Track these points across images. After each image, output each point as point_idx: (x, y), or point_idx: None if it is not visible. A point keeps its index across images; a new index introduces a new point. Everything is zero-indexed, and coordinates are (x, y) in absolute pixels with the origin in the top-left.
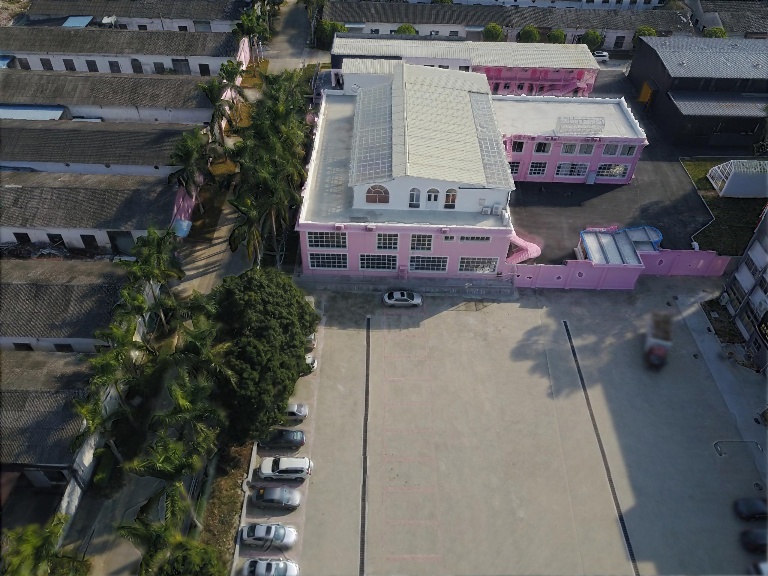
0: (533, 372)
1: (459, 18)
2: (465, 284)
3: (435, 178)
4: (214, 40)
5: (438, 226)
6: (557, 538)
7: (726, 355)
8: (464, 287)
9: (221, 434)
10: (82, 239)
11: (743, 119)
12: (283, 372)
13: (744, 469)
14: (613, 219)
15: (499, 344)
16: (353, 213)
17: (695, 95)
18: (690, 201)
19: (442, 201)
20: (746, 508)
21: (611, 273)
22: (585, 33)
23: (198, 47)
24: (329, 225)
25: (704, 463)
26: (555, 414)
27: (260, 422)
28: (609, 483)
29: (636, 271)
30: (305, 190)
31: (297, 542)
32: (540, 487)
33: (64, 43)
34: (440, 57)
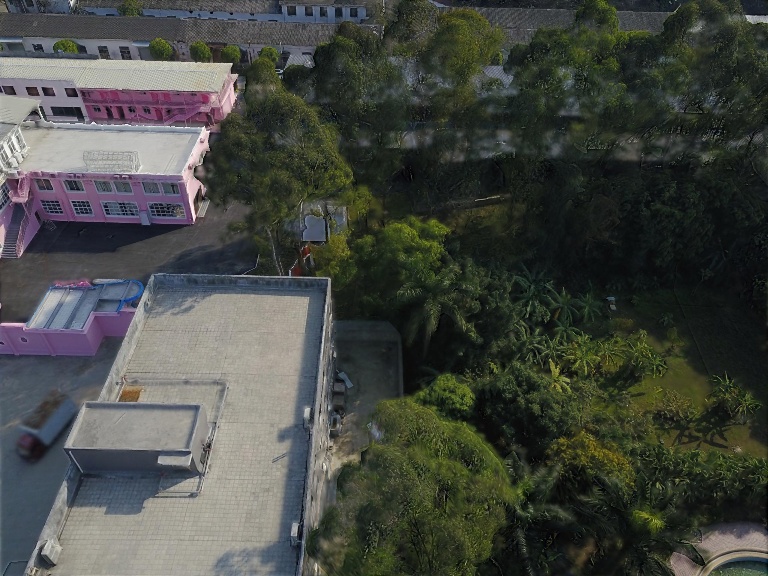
0: None
1: (128, 32)
2: None
3: None
4: None
5: None
6: None
7: None
8: None
9: None
10: None
11: None
12: None
13: None
14: (137, 268)
15: None
16: None
17: None
18: (245, 245)
19: None
20: None
21: (54, 339)
22: (261, 49)
23: None
24: None
25: None
26: None
27: None
28: None
29: (79, 337)
30: None
31: None
32: None
33: None
34: (45, 78)
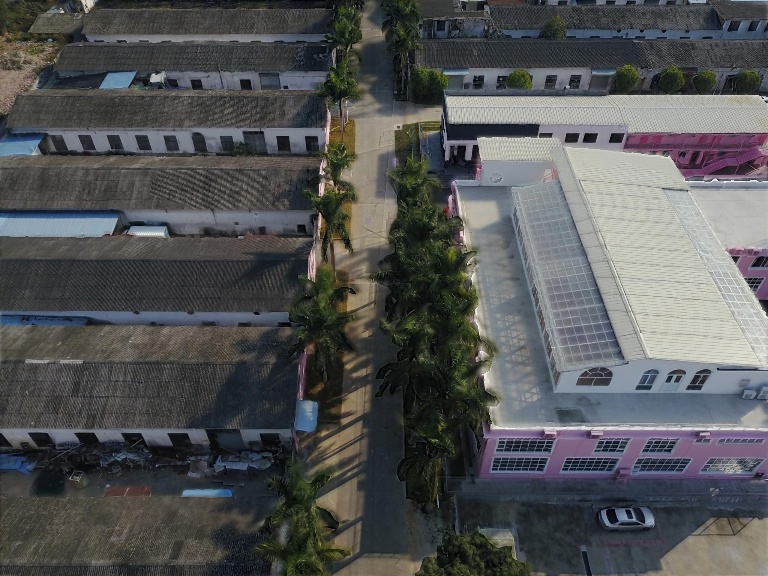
0: None
1: (583, 59)
2: (709, 490)
3: (688, 360)
4: (294, 105)
5: (693, 429)
6: None
7: None
8: (710, 495)
9: None
10: (170, 437)
11: None
12: None
13: None
14: None
15: None
16: (558, 402)
17: None
18: None
19: (686, 382)
20: None
21: None
22: (741, 74)
23: (275, 115)
24: (534, 431)
25: None
26: None
27: None
28: None
29: None
30: None
31: None
32: None
33: (108, 115)
34: (585, 122)
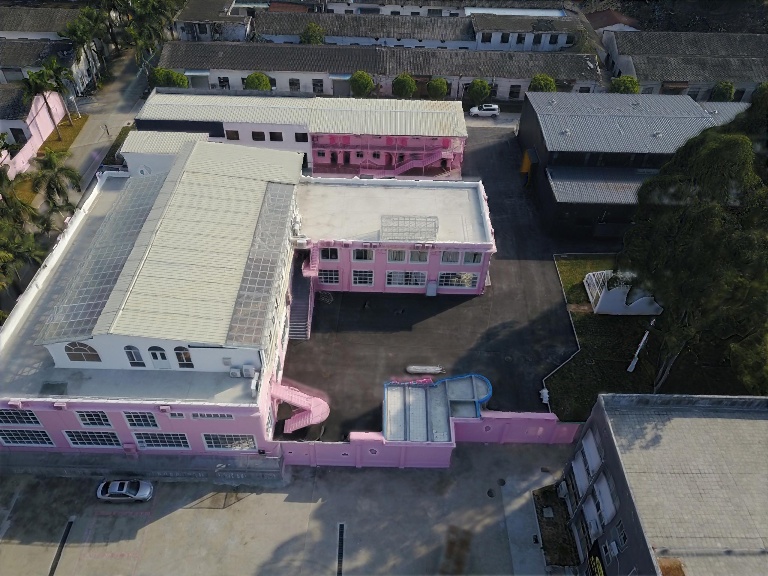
0: None
1: (323, 64)
2: (216, 466)
3: (150, 336)
4: (2, 98)
5: (154, 403)
6: None
7: None
8: (213, 471)
9: None
10: None
11: (632, 207)
12: None
13: None
14: (447, 351)
15: (236, 570)
16: (51, 376)
17: (579, 172)
18: (554, 321)
19: (173, 360)
20: None
21: (412, 451)
22: (471, 82)
23: None
24: (2, 402)
25: None
26: None
27: None
28: None
29: (445, 450)
30: None
31: None
32: None
33: None
34: (272, 121)
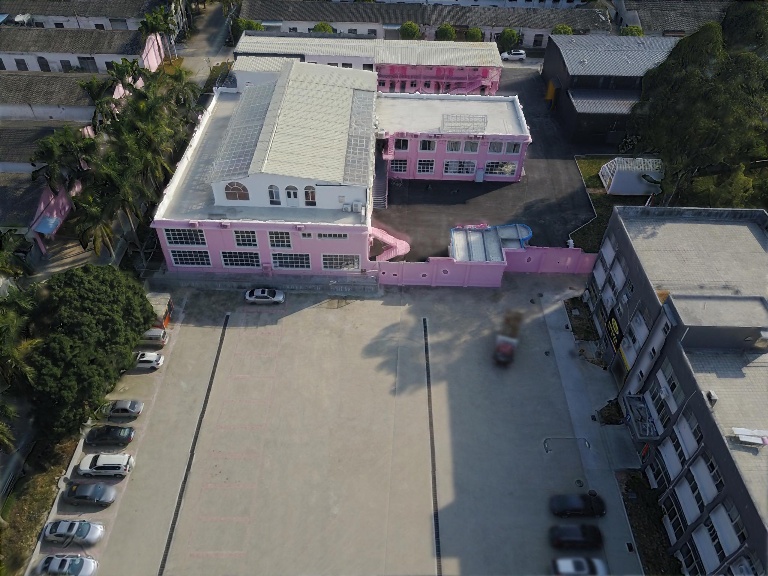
0: (380, 369)
1: (377, 16)
2: (329, 281)
3: (290, 175)
4: (121, 38)
5: (293, 223)
6: (366, 535)
7: (577, 352)
8: (328, 284)
9: (24, 430)
10: None
11: None
12: (93, 368)
13: (569, 466)
14: (494, 217)
15: (352, 341)
16: (213, 210)
17: (595, 93)
18: (576, 199)
19: (302, 198)
20: (559, 505)
21: (475, 270)
22: (502, 31)
23: (104, 45)
24: (184, 222)
25: (531, 460)
26: (393, 411)
27: (65, 418)
28: (432, 480)
29: (499, 268)
30: (168, 187)
31: (102, 538)
32: (361, 484)
33: None
34: (344, 55)
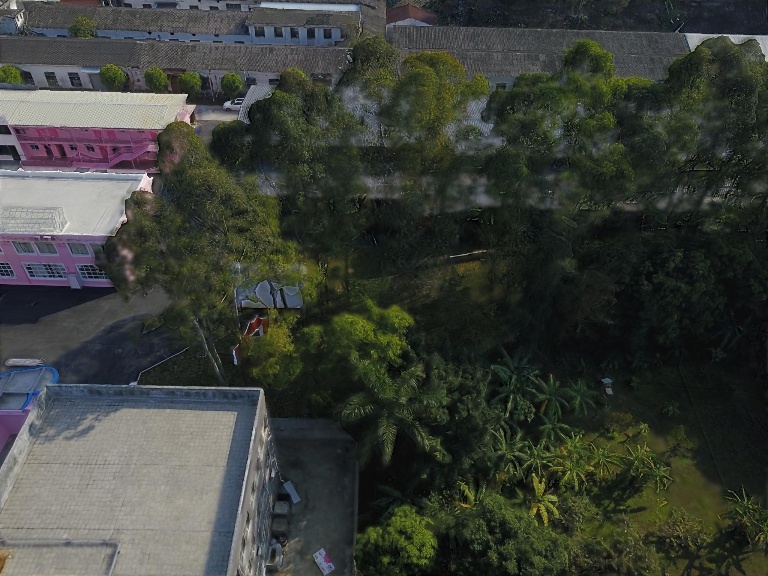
0: None
1: (77, 57)
2: None
3: None
4: None
5: None
6: None
7: None
8: None
9: None
10: None
11: None
12: None
13: None
14: (60, 344)
15: None
16: None
17: None
18: None
19: None
20: None
21: None
22: (223, 76)
23: None
24: None
25: None
26: None
27: None
28: None
29: None
30: None
31: None
32: None
33: None
34: None
